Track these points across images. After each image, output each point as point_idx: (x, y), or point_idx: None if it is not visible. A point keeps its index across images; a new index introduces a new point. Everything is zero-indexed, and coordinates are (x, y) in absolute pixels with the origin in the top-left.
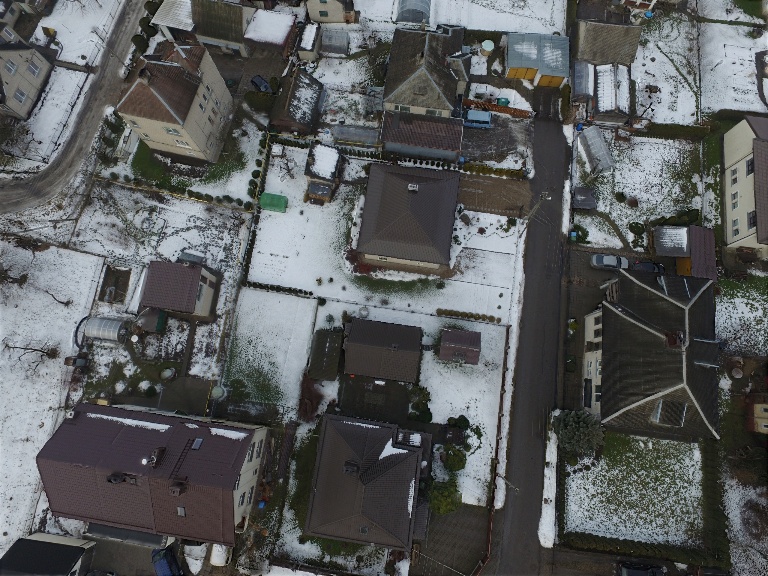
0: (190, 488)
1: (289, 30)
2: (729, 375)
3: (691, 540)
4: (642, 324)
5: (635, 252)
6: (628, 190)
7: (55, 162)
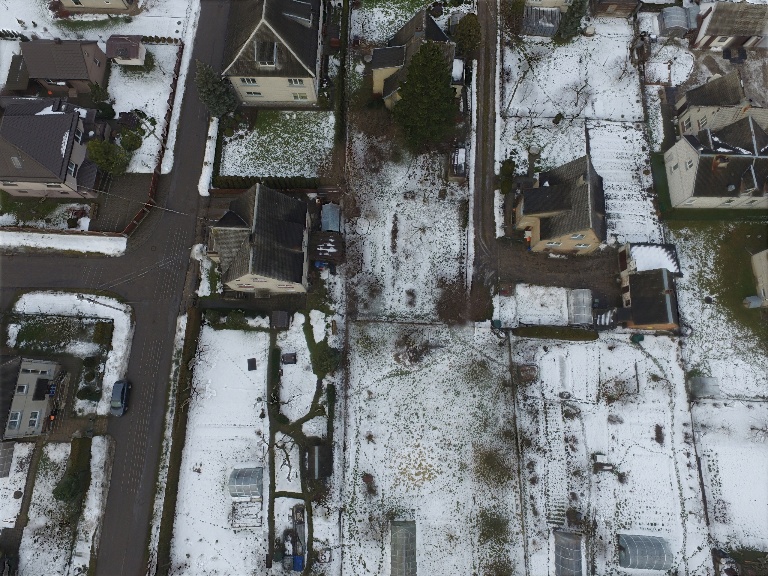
0: None
1: None
2: (363, 62)
3: None
4: None
5: None
6: None
7: None
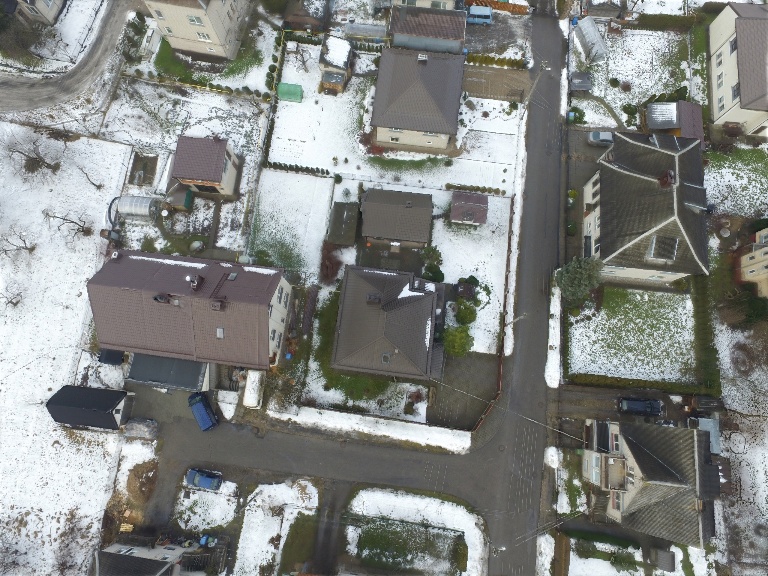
0: (229, 306)
1: None
2: (718, 235)
3: (685, 377)
4: (636, 174)
5: (629, 130)
6: (621, 76)
7: (82, 62)
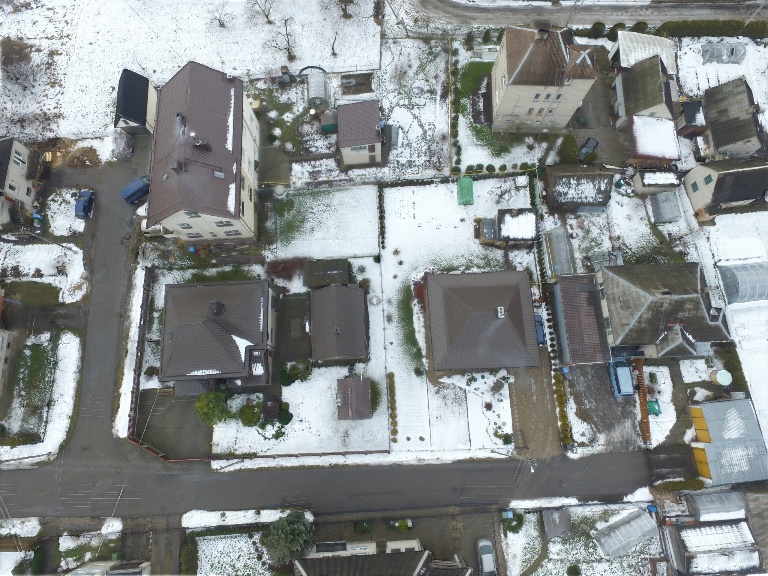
0: (180, 177)
1: (659, 156)
2: None
3: None
4: None
5: None
6: None
7: (456, 4)
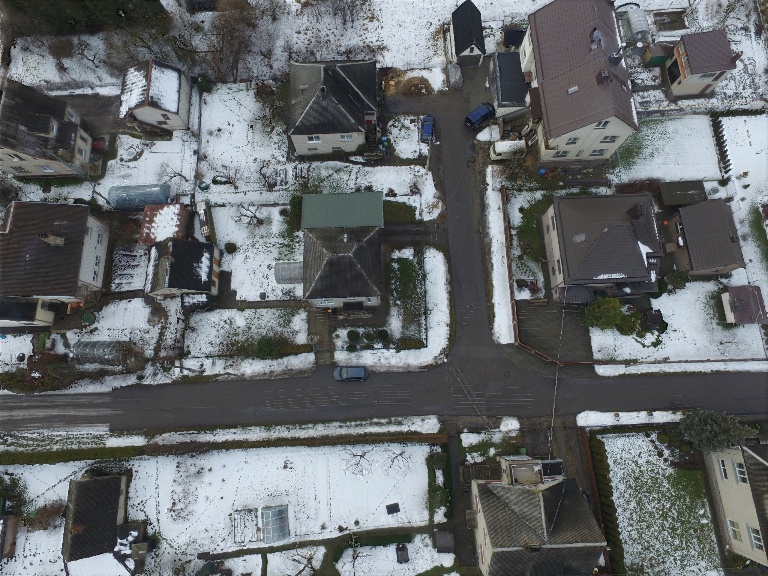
0: (604, 86)
1: None
2: None
3: (627, 569)
4: None
5: None
6: None
7: None
